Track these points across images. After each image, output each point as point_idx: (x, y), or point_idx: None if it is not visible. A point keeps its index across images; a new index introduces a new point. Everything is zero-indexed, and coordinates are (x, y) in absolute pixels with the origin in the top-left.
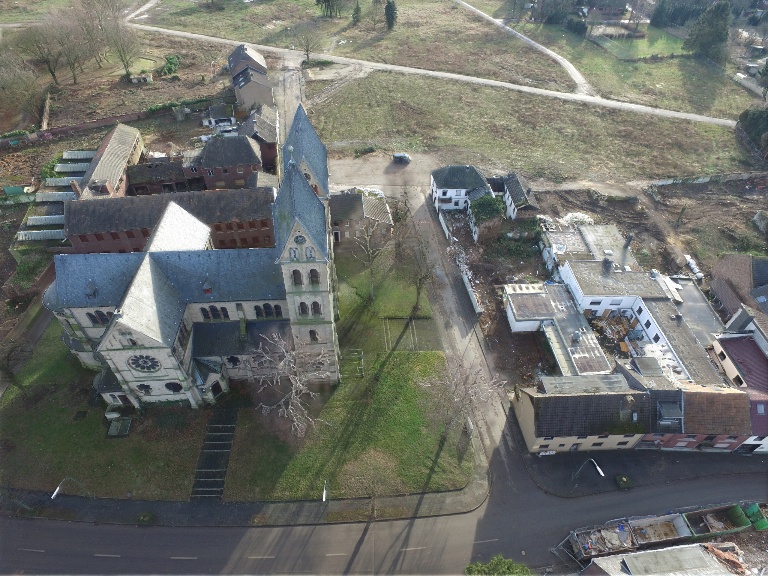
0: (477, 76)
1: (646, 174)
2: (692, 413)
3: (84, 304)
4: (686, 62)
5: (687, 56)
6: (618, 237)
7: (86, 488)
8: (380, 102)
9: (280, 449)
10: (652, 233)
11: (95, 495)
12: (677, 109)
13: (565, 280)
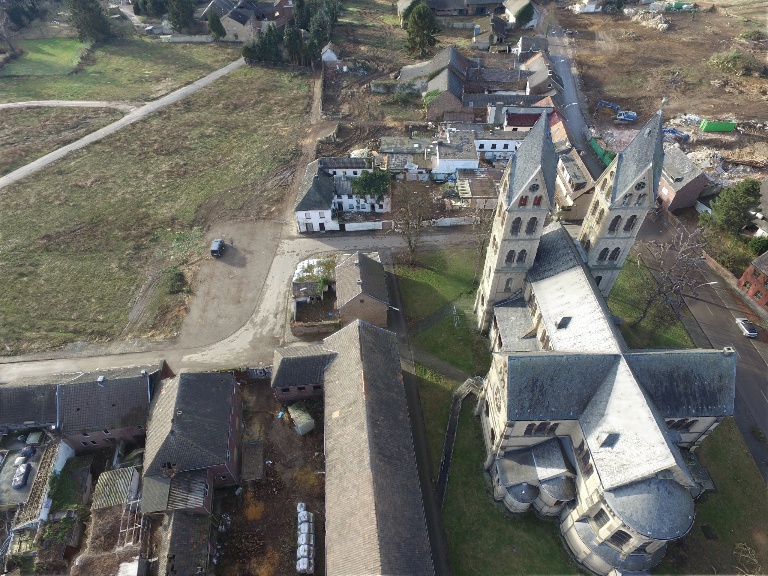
0: (20, 165)
1: (301, 113)
2: (573, 143)
3: (680, 454)
4: (108, 49)
5: (98, 45)
6: (398, 139)
7: (766, 499)
8: (24, 262)
9: (657, 342)
10: (382, 129)
11: (766, 488)
12: (200, 76)
13: (448, 171)
